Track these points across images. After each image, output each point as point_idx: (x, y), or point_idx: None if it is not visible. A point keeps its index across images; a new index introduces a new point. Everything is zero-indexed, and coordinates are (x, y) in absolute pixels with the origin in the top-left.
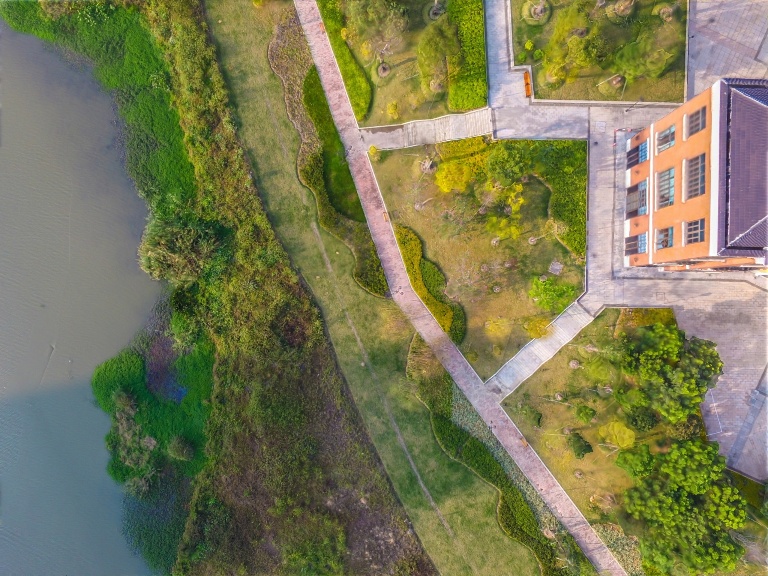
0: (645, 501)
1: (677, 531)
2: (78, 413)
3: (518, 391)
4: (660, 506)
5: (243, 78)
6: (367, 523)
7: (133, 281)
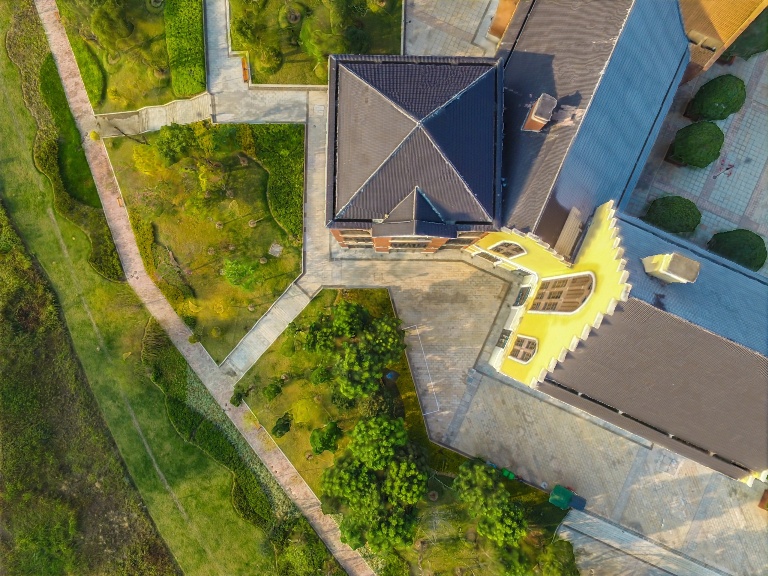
0: (332, 478)
1: (359, 507)
2: None
3: (250, 373)
4: (341, 482)
5: None
6: (102, 507)
7: None
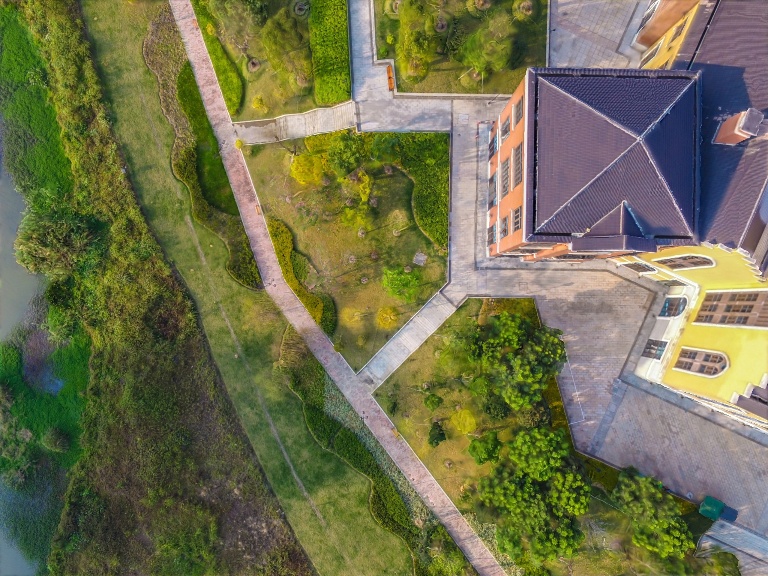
0: (493, 488)
1: (523, 518)
2: None
3: (388, 381)
4: (505, 493)
5: (118, 74)
6: (240, 513)
7: (10, 275)
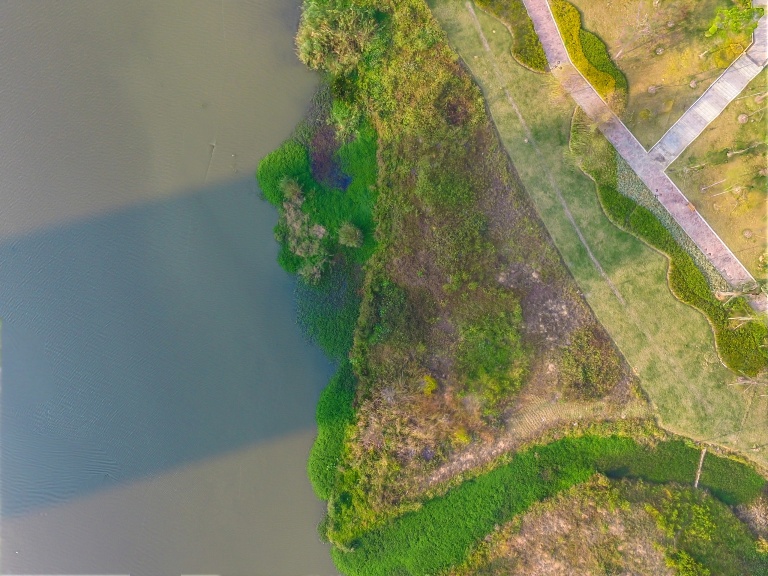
0: None
1: None
2: (245, 206)
3: (683, 156)
4: None
5: None
6: (540, 297)
7: (291, 71)
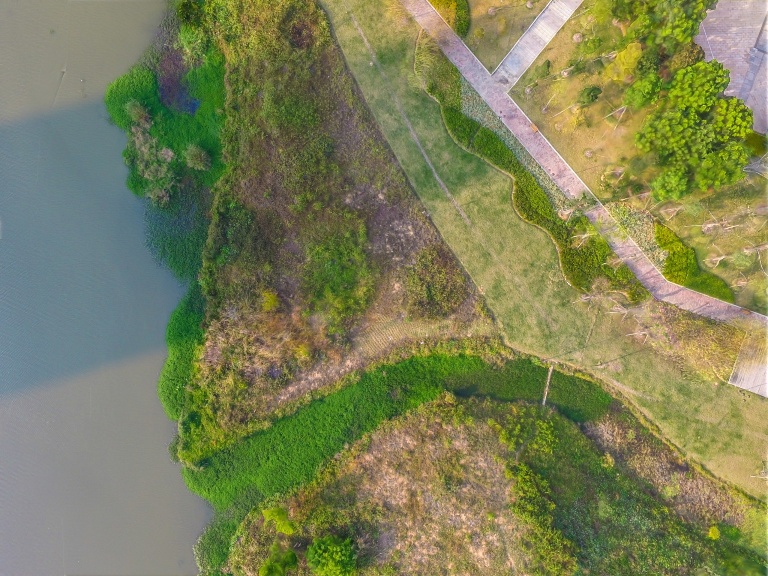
0: (655, 127)
1: (687, 149)
2: (94, 131)
3: (525, 77)
4: (670, 125)
5: None
6: (386, 218)
7: None
